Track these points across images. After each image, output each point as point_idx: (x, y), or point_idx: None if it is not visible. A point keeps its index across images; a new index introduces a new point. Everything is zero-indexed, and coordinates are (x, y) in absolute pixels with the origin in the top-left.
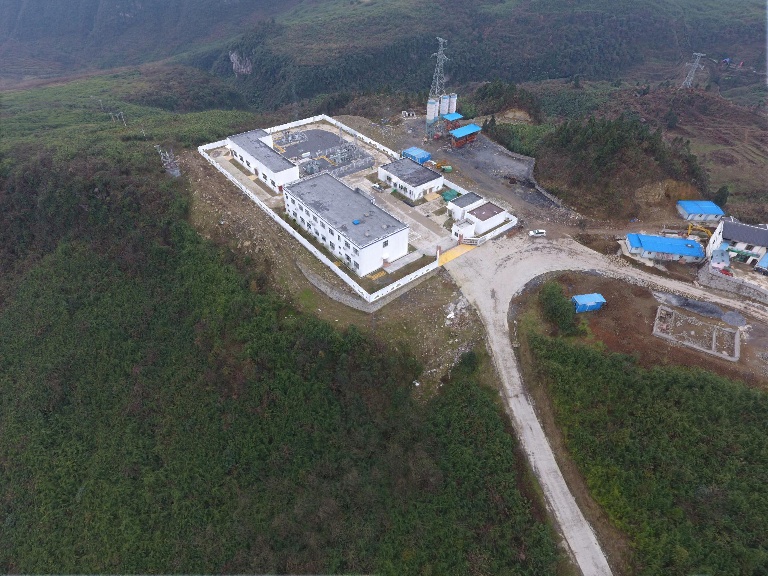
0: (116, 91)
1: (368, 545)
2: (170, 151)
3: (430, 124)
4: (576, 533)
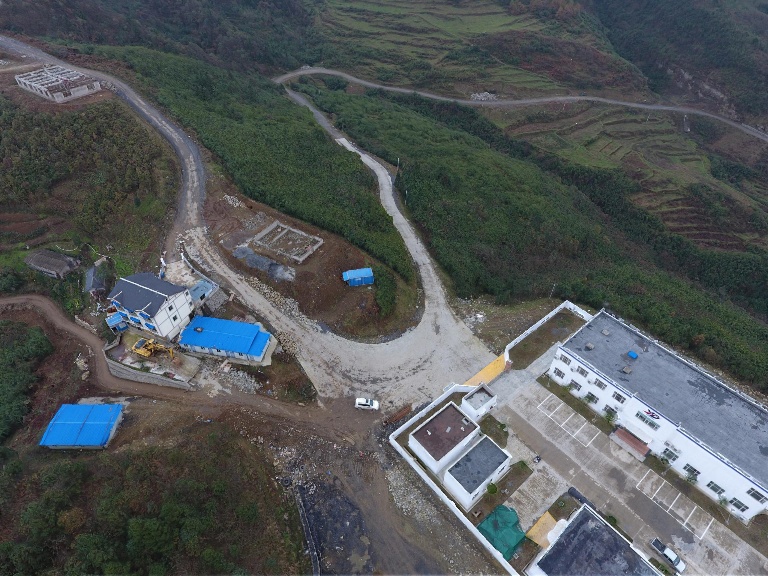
0: None
1: None
2: None
3: None
4: (401, 222)
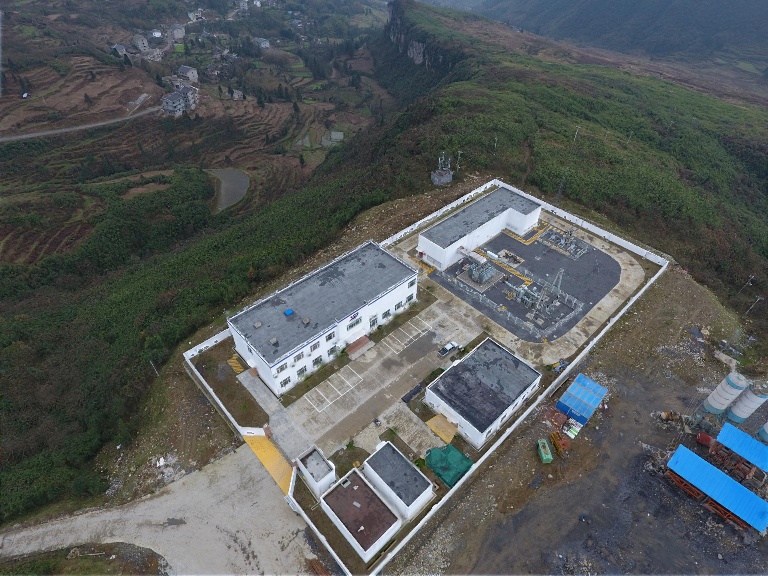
0: (735, 127)
1: (2, 427)
2: (495, 169)
3: (706, 408)
4: None
